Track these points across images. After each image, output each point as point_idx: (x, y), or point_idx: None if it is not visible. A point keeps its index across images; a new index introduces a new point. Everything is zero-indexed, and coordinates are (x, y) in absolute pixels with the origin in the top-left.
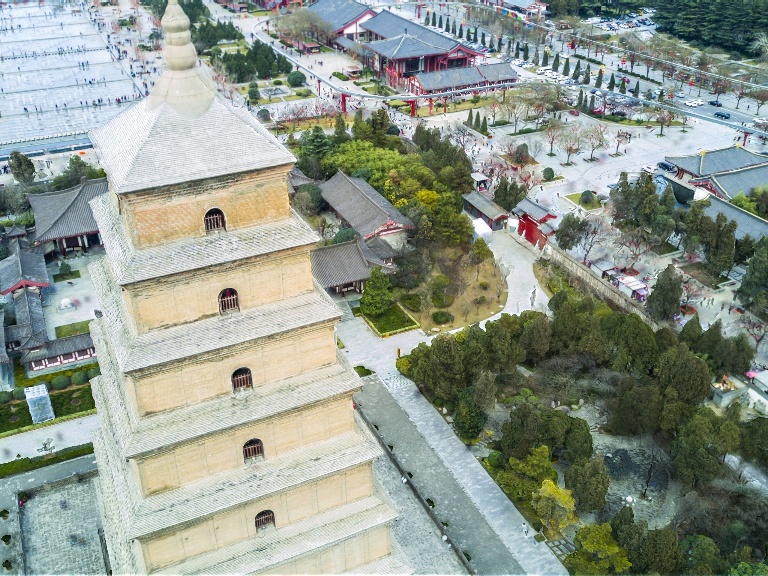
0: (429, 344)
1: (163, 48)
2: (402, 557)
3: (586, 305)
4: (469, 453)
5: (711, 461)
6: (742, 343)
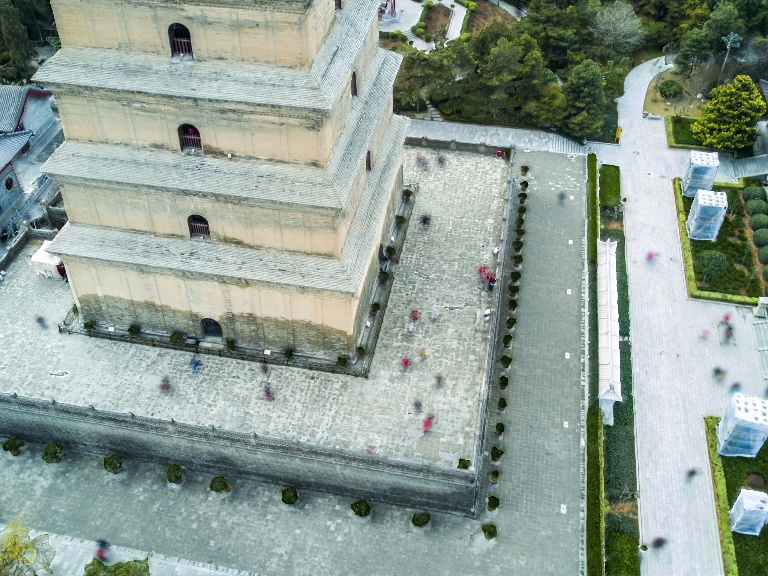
0: None
1: None
2: (66, 241)
3: None
4: None
5: None
6: None
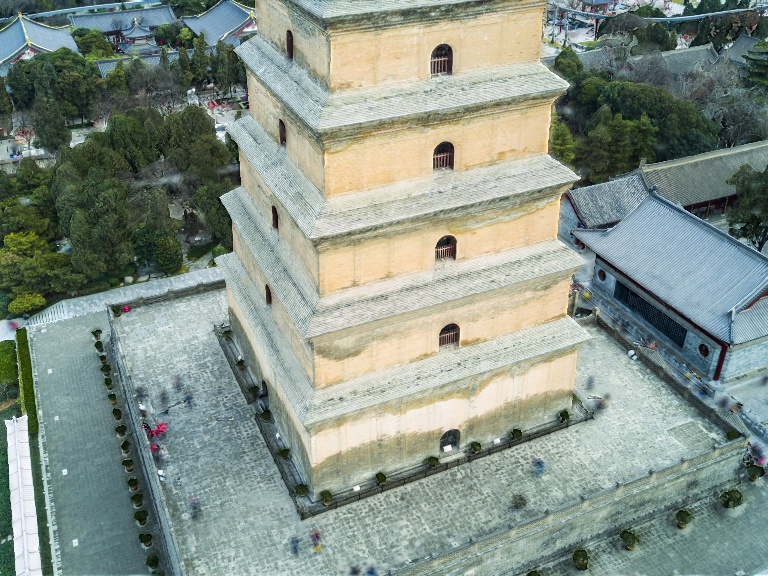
0: None
1: None
2: None
3: (33, 164)
4: (200, 271)
5: None
6: None
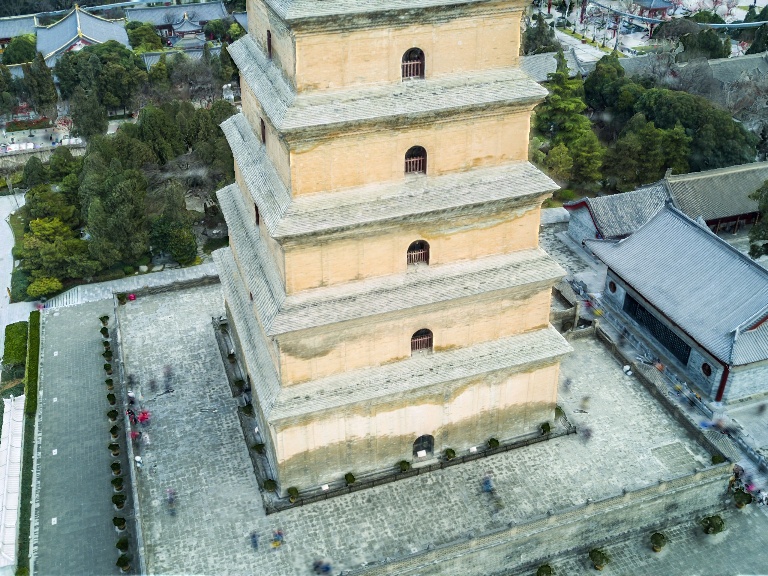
0: (0, 279)
1: None
2: None
3: (67, 152)
4: None
5: None
6: None
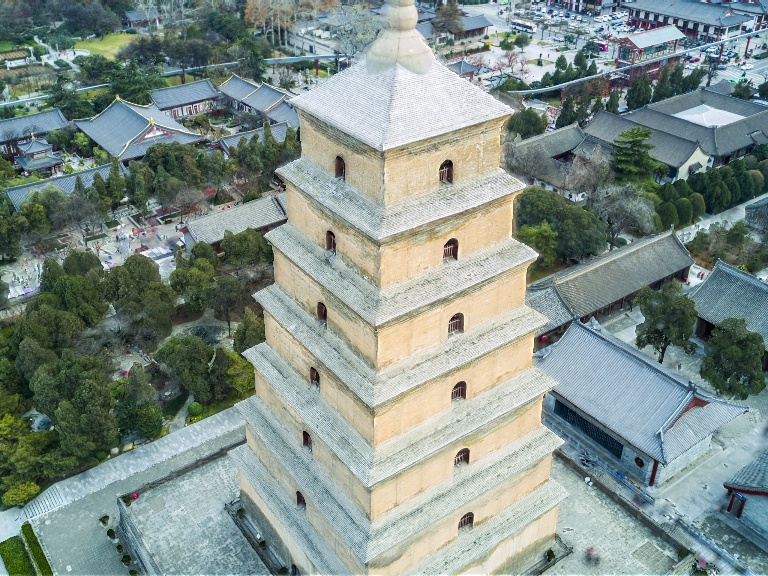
0: None
1: (412, 8)
2: None
3: None
4: (181, 431)
5: (232, 277)
6: (81, 254)
